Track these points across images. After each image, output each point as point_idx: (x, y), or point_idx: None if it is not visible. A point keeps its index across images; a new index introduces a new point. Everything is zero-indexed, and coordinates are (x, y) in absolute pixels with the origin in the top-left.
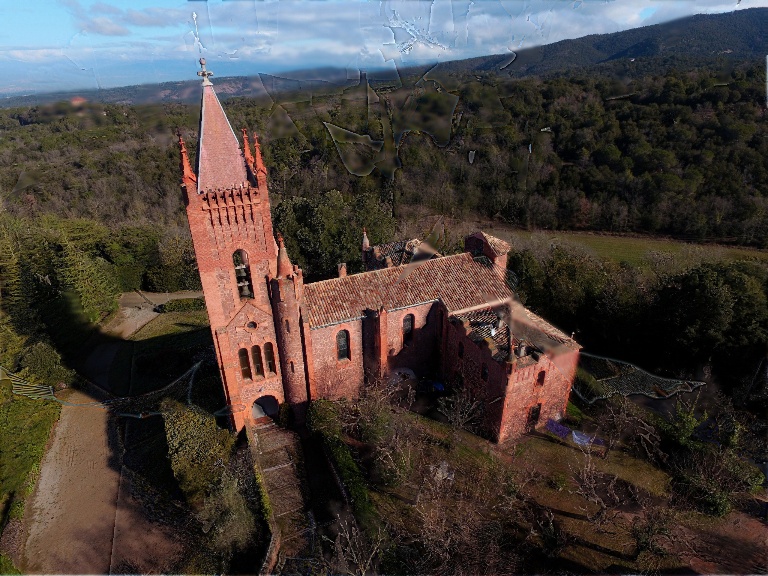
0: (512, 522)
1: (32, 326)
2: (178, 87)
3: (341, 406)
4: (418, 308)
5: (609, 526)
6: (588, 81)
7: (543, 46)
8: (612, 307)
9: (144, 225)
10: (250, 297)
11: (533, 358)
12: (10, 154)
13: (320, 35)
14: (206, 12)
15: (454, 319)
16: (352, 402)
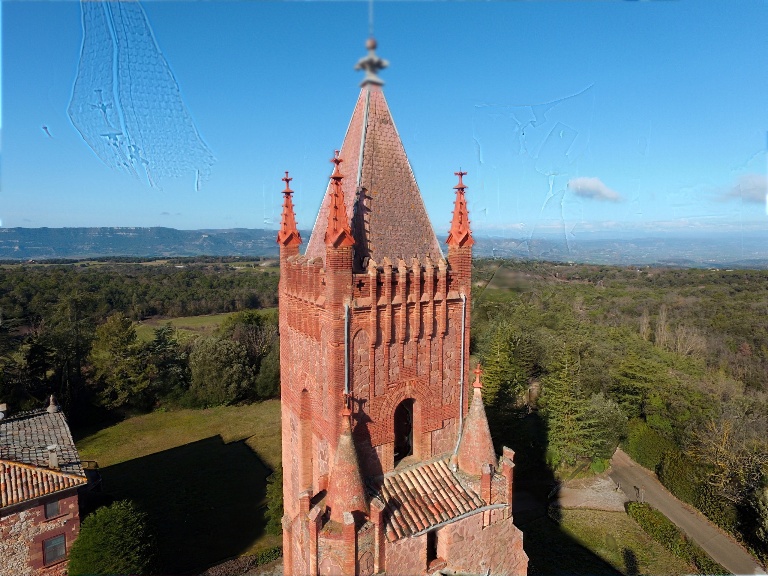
0: None
1: None
2: None
3: None
4: None
5: None
6: None
7: None
8: None
9: (764, 403)
10: None
11: None
12: (574, 266)
13: None
14: None
15: None
16: None
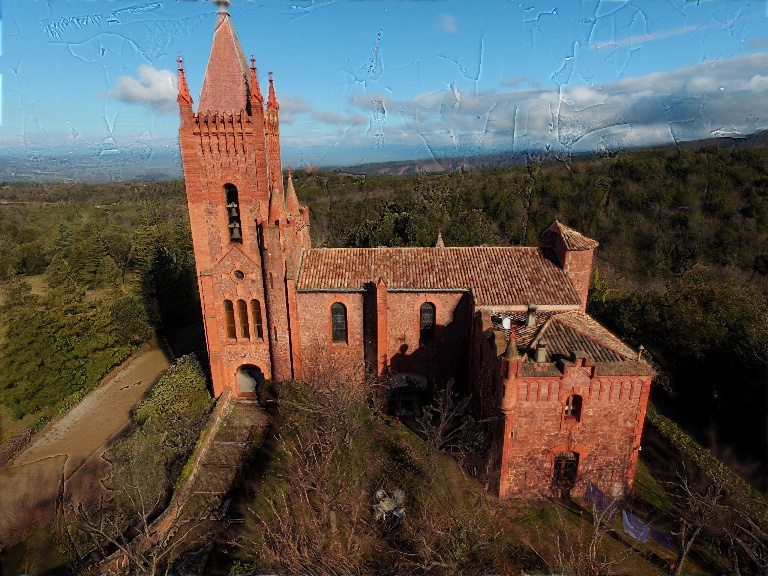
0: (380, 573)
1: (147, 290)
2: (329, 115)
3: (328, 399)
4: (441, 297)
5: None
6: None
7: (750, 67)
8: (763, 351)
9: None
10: (241, 242)
11: (557, 367)
12: None
13: None
14: None
15: None
16: None
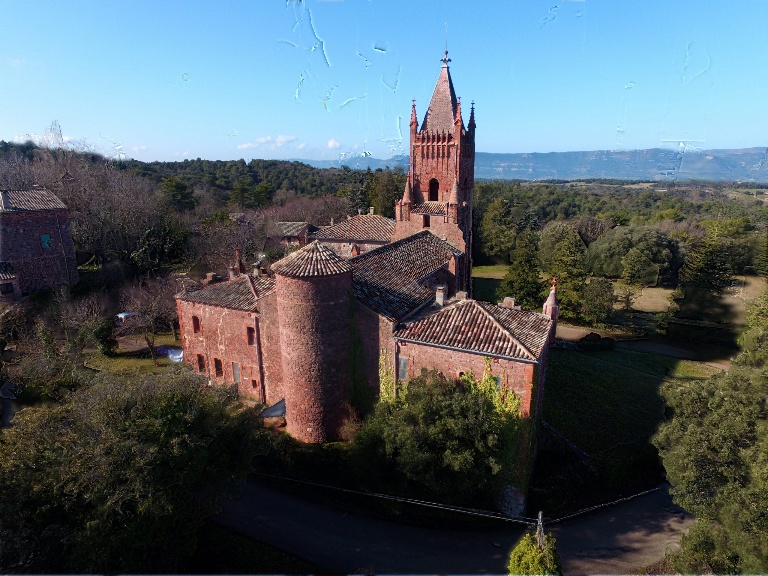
0: None
1: None
2: None
3: None
4: None
5: (166, 340)
6: None
7: None
8: None
9: None
10: None
11: None
12: None
13: (336, 41)
14: None
15: None
16: None
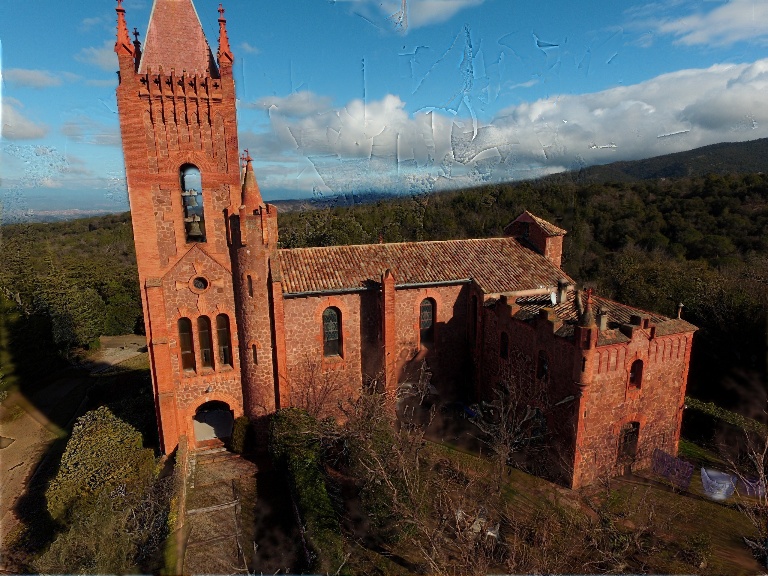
0: None
1: None
2: None
3: None
4: (441, 291)
5: None
6: (634, 126)
7: None
8: (721, 310)
9: None
10: (201, 241)
11: (622, 333)
12: None
13: None
14: (241, 67)
15: (493, 302)
16: (343, 426)
